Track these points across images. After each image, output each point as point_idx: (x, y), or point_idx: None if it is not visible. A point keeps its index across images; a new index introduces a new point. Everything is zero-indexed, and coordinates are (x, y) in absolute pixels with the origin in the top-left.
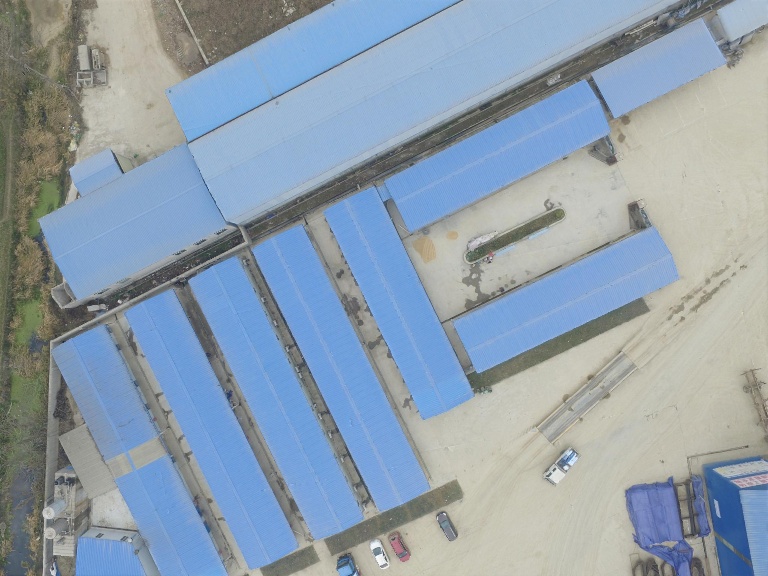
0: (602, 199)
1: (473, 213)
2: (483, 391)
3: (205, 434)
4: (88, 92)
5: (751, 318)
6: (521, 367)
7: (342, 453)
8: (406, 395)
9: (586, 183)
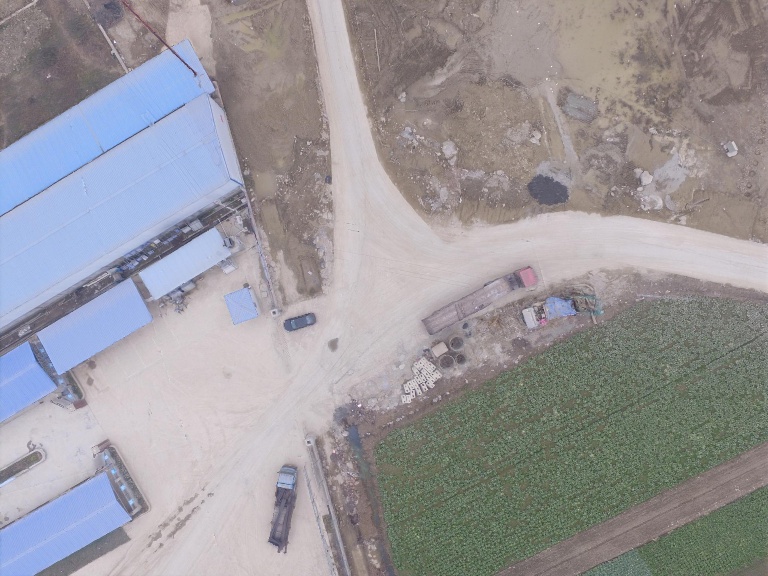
0: (79, 438)
1: None
2: None
3: None
4: None
5: (222, 541)
6: None
7: None
8: None
9: (63, 424)
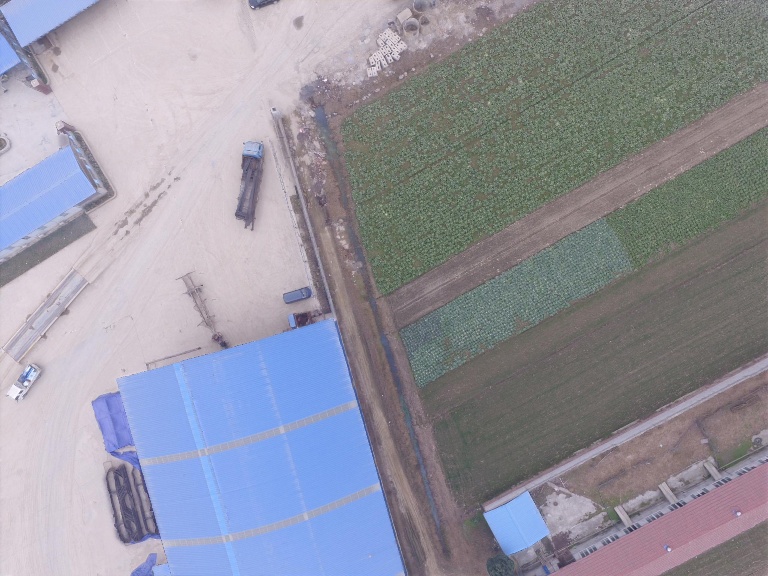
0: (44, 126)
1: None
2: None
3: None
4: None
5: (189, 226)
6: None
7: None
8: None
9: (28, 113)
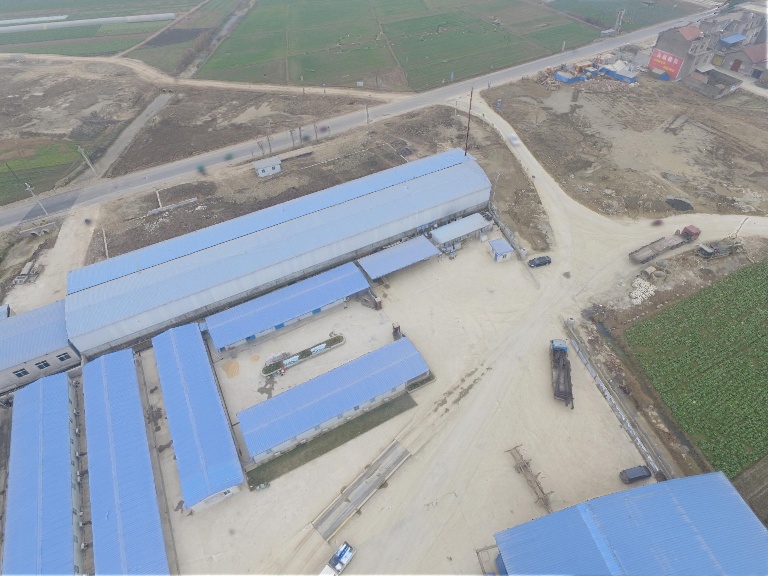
0: (373, 330)
1: (274, 343)
2: (259, 485)
3: None
4: (18, 287)
5: (506, 407)
6: (301, 461)
7: (89, 572)
8: (181, 497)
9: (361, 321)
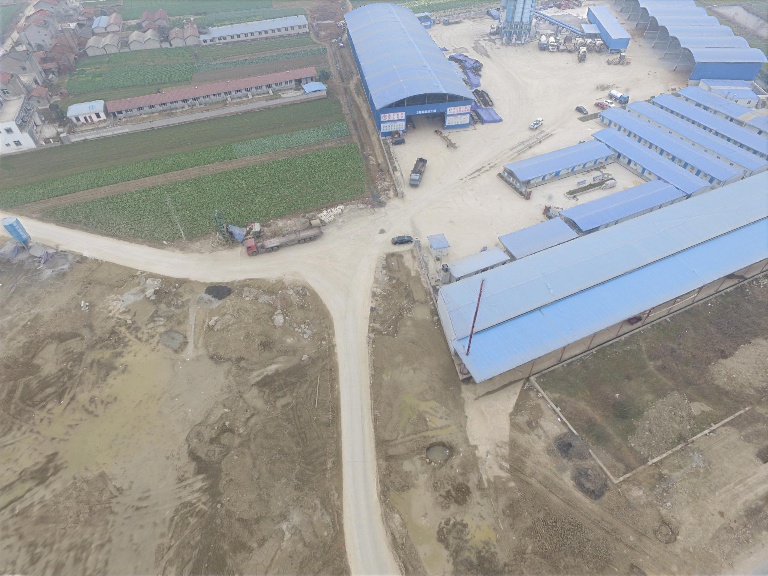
0: (545, 201)
1: None
2: None
3: (722, 121)
4: None
5: None
6: None
7: None
8: None
9: None
